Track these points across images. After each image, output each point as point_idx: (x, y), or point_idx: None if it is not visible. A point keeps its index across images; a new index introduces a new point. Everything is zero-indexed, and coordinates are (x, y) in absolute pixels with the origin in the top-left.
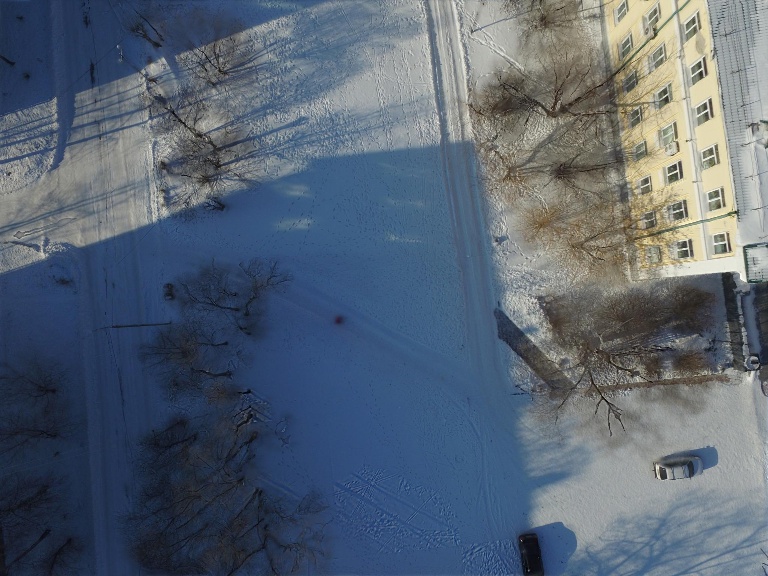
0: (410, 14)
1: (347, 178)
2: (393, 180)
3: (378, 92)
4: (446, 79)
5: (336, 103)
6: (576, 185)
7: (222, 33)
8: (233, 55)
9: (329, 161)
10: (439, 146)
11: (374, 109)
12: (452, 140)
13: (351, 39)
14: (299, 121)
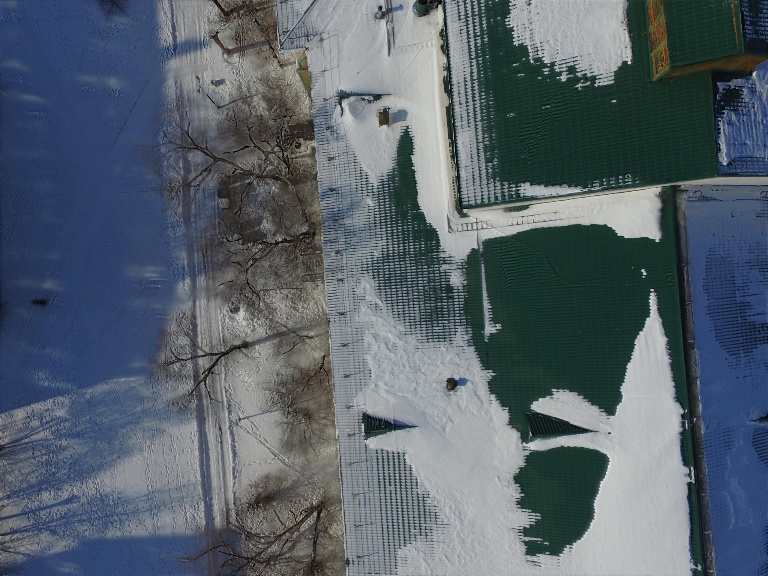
0: (181, 399)
1: (115, 558)
2: (158, 562)
3: (147, 475)
4: (213, 464)
5: (107, 484)
6: (334, 575)
7: (2, 407)
8: (11, 430)
9: (98, 540)
10: (203, 532)
11: (142, 493)
12: (217, 525)
13: (123, 421)
14: (71, 499)
